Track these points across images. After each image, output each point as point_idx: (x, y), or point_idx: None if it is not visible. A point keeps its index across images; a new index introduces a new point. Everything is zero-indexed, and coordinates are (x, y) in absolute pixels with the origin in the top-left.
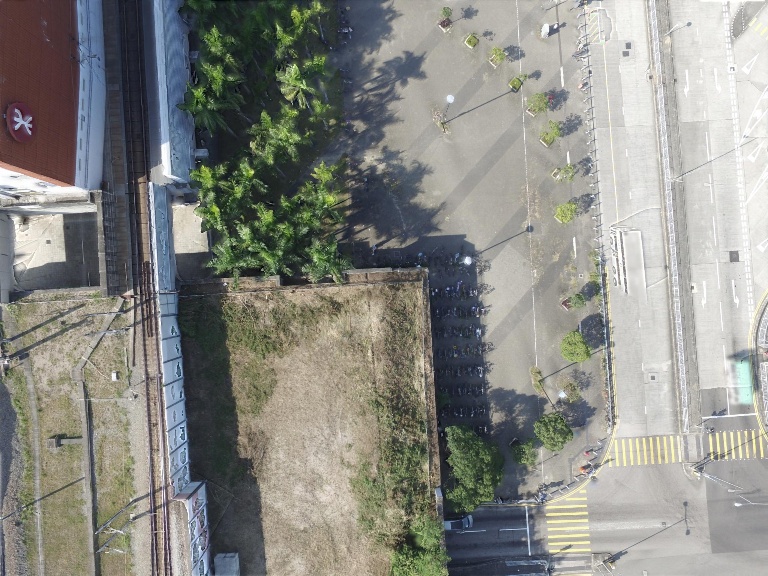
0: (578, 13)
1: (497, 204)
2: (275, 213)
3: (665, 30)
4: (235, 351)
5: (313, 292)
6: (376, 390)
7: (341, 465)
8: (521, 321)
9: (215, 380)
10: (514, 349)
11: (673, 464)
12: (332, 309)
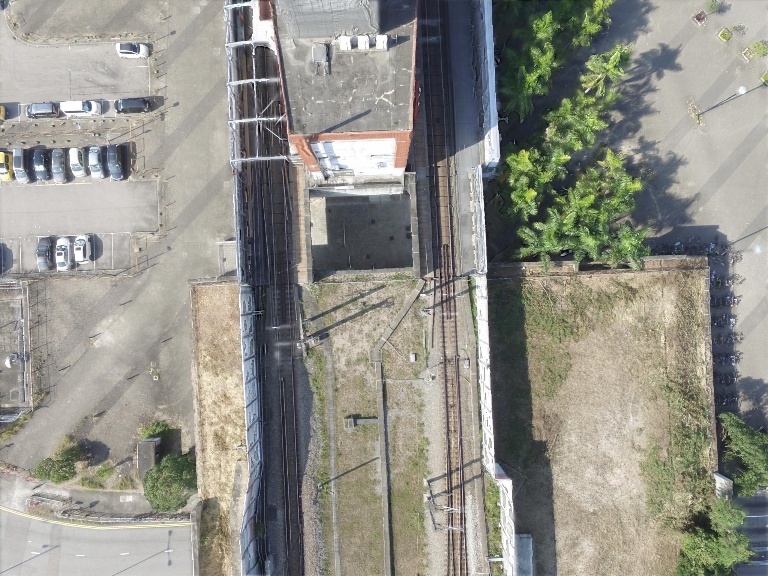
0: None
1: (749, 196)
2: None
3: None
4: (532, 335)
5: (609, 278)
6: (668, 375)
7: (632, 449)
8: None
9: (511, 363)
10: (763, 339)
11: None
12: (630, 295)
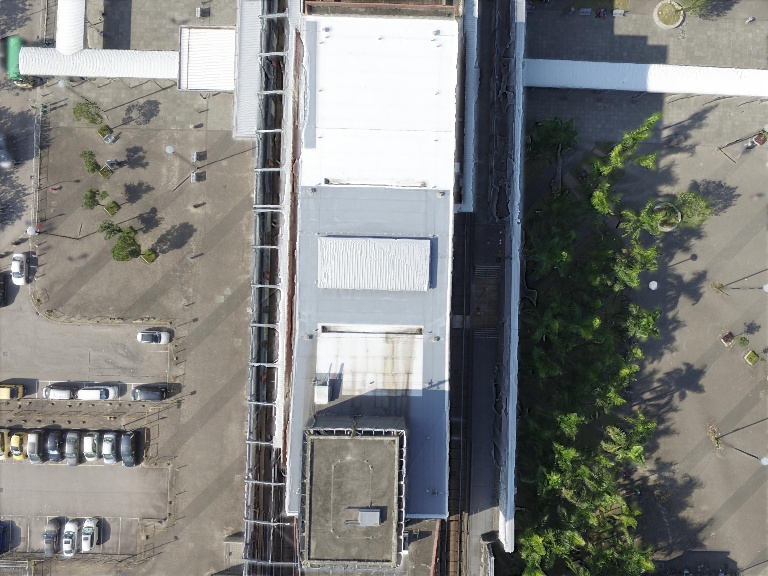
0: None
1: (763, 523)
2: (591, 573)
3: None
4: None
5: None
6: None
7: None
8: None
9: None
10: None
11: None
12: None
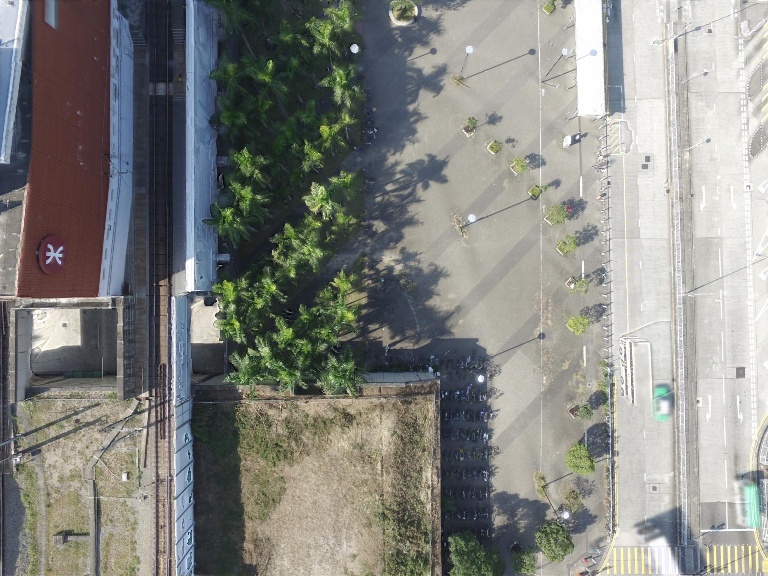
0: (600, 124)
1: (510, 310)
2: (293, 326)
3: (684, 145)
4: (246, 457)
5: (326, 403)
6: (383, 503)
7: (345, 575)
8: (528, 427)
9: (225, 485)
10: (520, 454)
11: (670, 575)
12: (344, 422)
